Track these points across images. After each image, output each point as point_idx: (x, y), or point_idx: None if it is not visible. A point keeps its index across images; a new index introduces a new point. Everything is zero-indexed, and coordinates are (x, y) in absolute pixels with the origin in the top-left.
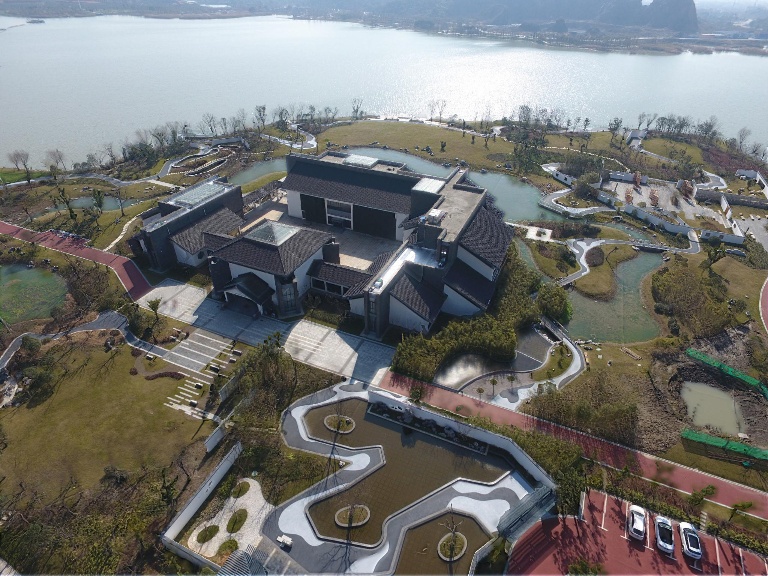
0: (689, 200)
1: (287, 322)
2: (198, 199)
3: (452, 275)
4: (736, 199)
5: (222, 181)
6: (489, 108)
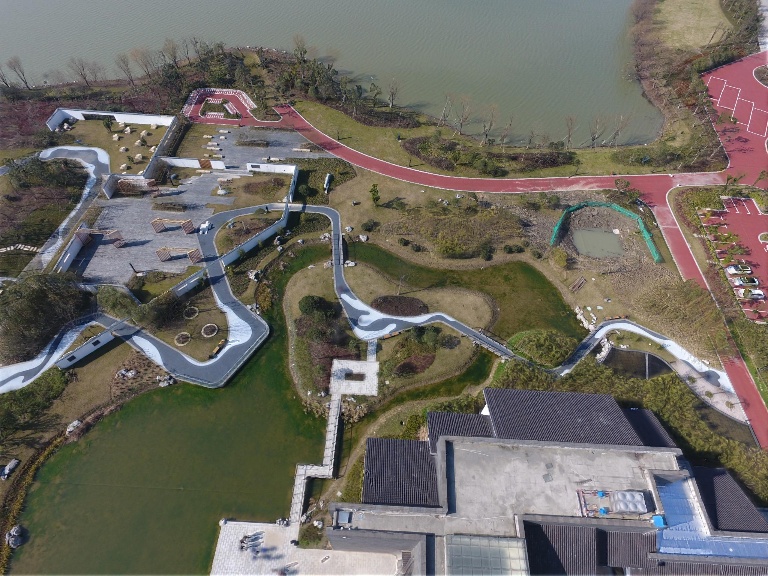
0: (162, 192)
1: None
2: None
3: None
4: (165, 149)
5: None
6: None
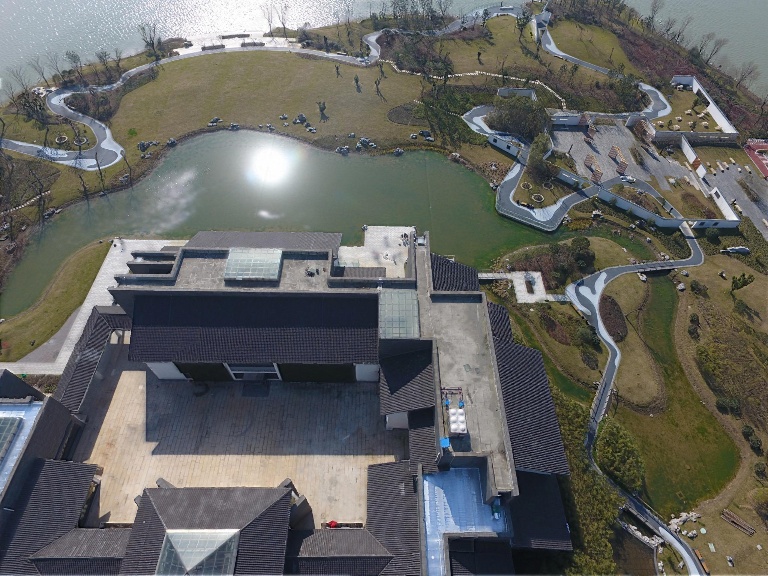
0: (649, 149)
1: None
2: None
3: (516, 521)
4: (695, 138)
5: (2, 384)
6: (350, 4)
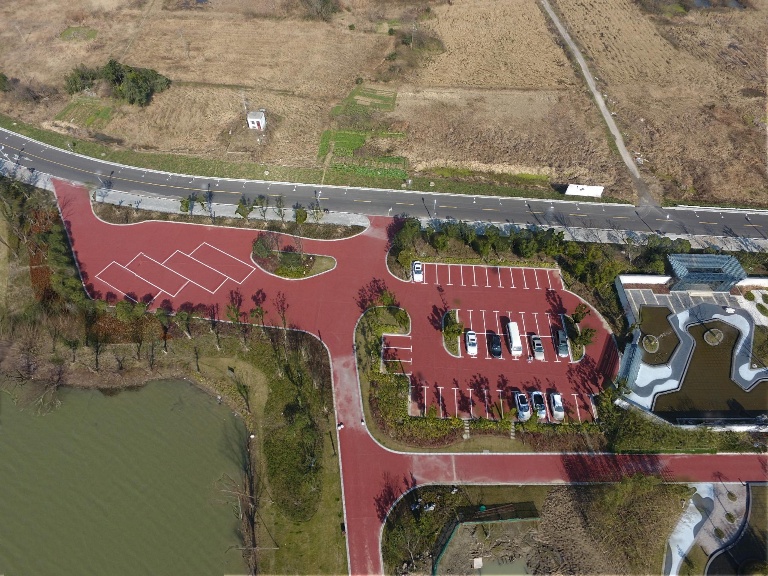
0: None
1: None
2: None
3: None
4: None
5: None
6: None
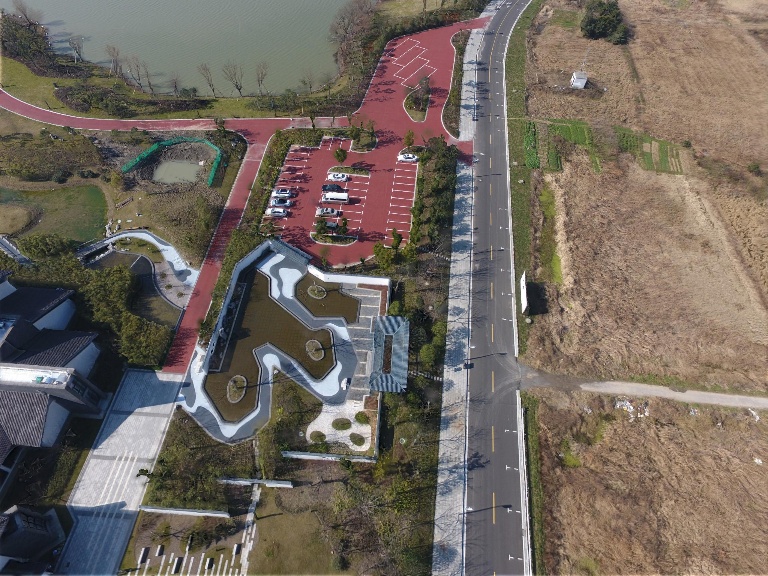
0: None
1: (73, 523)
2: None
3: None
4: None
5: None
6: None
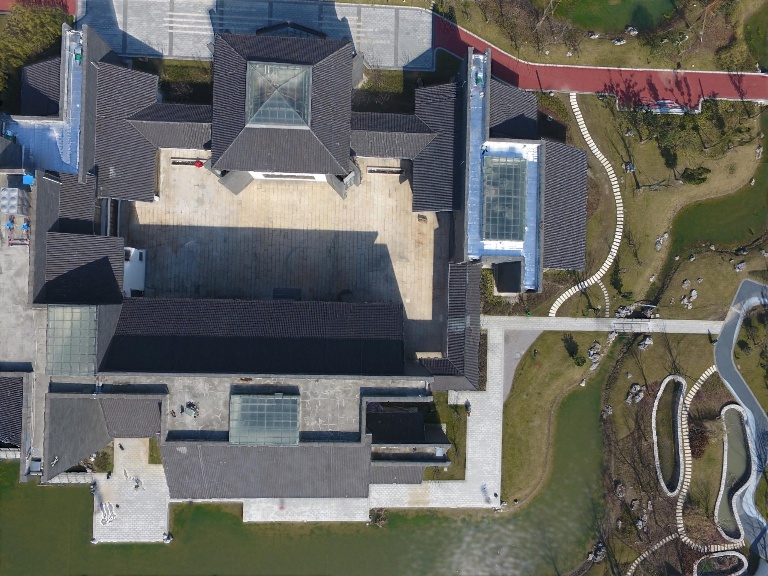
0: None
1: None
2: (489, 175)
3: None
4: None
5: None
6: None
